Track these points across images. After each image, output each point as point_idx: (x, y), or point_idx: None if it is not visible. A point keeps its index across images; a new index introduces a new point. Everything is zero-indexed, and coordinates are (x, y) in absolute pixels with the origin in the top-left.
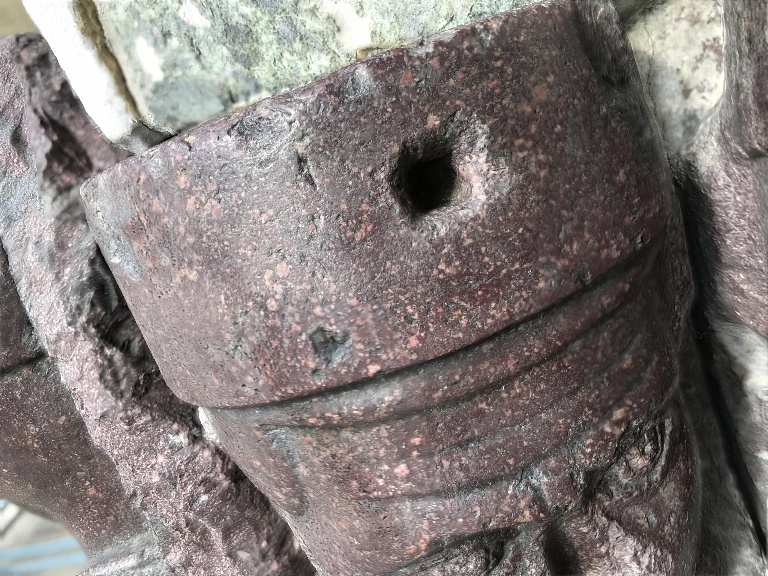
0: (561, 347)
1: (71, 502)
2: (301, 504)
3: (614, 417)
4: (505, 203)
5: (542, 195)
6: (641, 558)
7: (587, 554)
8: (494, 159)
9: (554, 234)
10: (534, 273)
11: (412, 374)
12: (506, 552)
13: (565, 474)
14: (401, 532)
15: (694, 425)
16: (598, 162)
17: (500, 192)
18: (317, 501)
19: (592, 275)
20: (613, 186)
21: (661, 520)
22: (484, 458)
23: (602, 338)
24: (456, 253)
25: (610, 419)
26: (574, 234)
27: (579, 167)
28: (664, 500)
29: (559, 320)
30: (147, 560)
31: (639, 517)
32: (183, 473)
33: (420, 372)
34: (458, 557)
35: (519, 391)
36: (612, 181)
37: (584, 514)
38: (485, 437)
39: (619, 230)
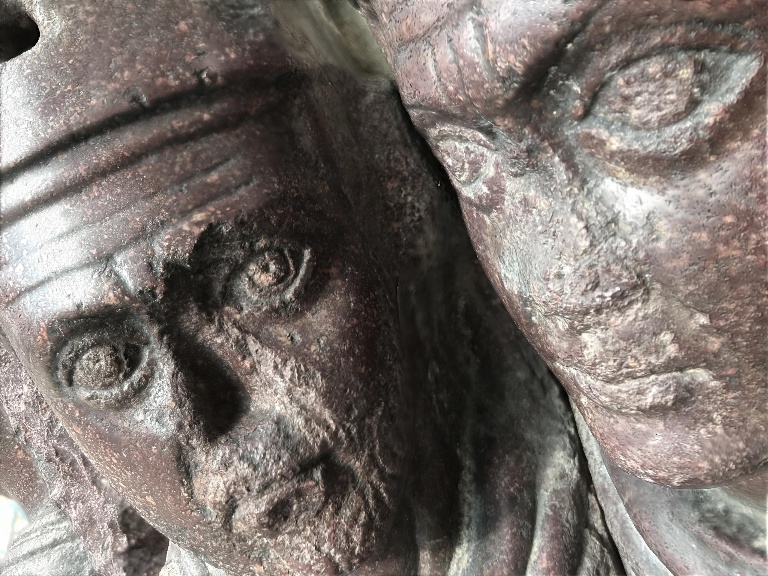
0: (132, 158)
1: (7, 467)
2: (4, 338)
3: (194, 219)
4: (56, 42)
5: (90, 36)
6: (285, 372)
7: (241, 373)
8: (45, 11)
9: (103, 64)
10: (86, 94)
11: (8, 183)
12: (144, 358)
13: (143, 262)
14: (30, 325)
15: (508, 338)
16: (151, 14)
17: (53, 35)
18: (3, 326)
19: (147, 98)
20: (170, 33)
21: (307, 340)
22: (72, 249)
23: (180, 156)
24: (19, 81)
25: (189, 220)
26: (125, 65)
27: (129, 17)
28: (313, 324)
29: (127, 137)
30: (65, 517)
31: (281, 335)
32: (42, 400)
33: (14, 181)
34: (89, 353)
35: (97, 194)
36: (169, 29)
37: (209, 322)
38: (72, 233)
39: (176, 65)
